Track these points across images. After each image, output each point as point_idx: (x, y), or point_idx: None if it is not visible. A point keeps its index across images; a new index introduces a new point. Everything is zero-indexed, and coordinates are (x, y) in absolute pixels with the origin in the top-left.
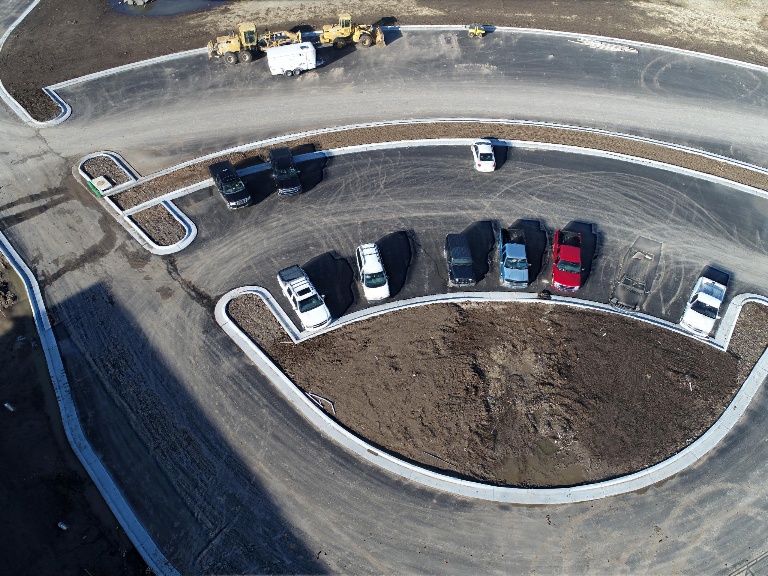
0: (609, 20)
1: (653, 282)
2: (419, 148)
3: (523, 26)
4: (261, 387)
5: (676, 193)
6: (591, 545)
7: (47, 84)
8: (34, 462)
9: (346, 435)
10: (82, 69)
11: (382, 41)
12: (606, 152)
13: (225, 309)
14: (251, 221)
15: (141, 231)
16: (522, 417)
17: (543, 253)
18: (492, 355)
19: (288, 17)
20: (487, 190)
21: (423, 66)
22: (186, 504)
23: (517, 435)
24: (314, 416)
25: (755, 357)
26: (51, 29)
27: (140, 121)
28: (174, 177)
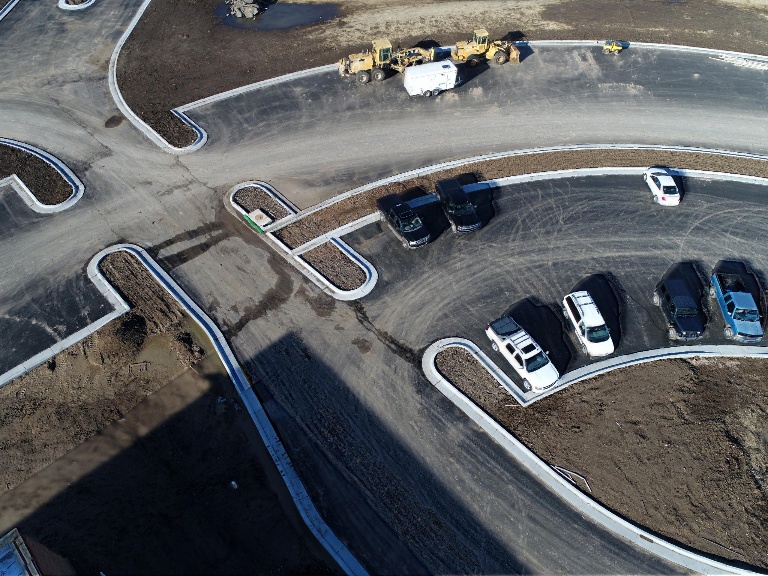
0: (748, 35)
1: None
2: (588, 178)
3: (658, 42)
4: (499, 458)
5: None
6: None
7: (175, 105)
8: (276, 551)
9: (611, 517)
10: (207, 88)
11: (517, 58)
12: None
13: (434, 365)
14: (432, 262)
15: (318, 273)
16: None
17: (759, 300)
18: (742, 420)
19: (410, 31)
20: (675, 226)
21: (565, 86)
22: None
23: None
24: (568, 494)
25: None
26: (163, 44)
27: (282, 147)
28: (335, 210)
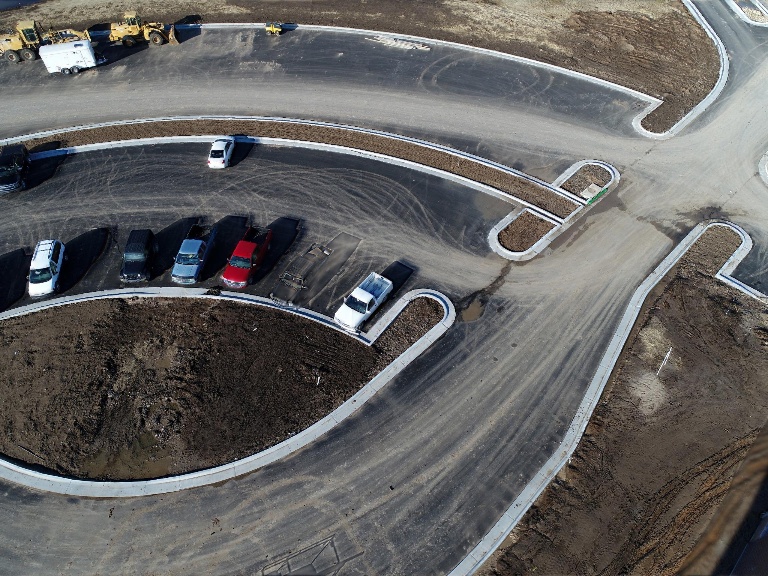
0: (412, 18)
1: (333, 277)
2: (165, 145)
3: (325, 24)
4: None
5: (401, 189)
6: (141, 537)
7: None
8: None
9: None
10: None
11: (174, 39)
12: (350, 149)
13: None
14: None
15: None
16: (135, 411)
17: None
18: (134, 350)
19: (91, 15)
20: (211, 187)
21: (207, 64)
22: None
23: (122, 429)
24: None
25: (400, 351)
26: None
27: None
28: None
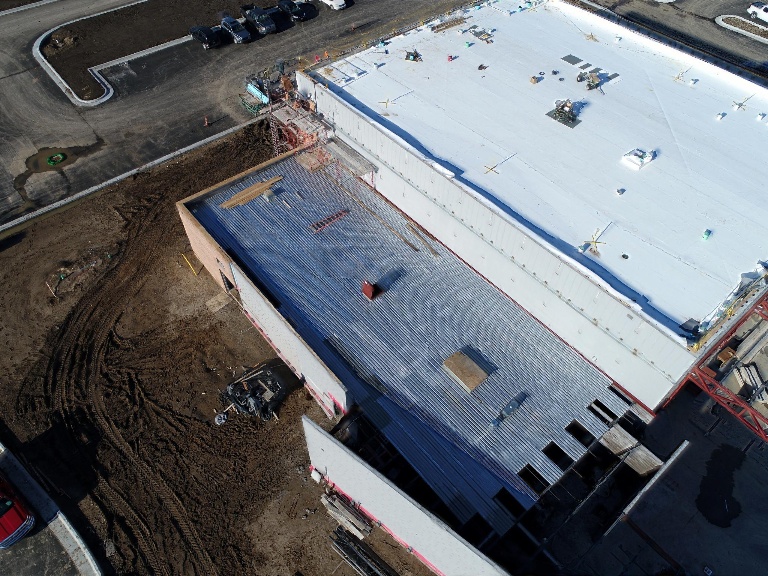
0: None
1: None
2: None
3: None
4: (767, 47)
5: None
6: None
7: None
8: None
9: None
10: None
11: None
12: None
13: None
14: None
15: None
16: None
17: None
18: None
19: None
20: None
21: None
22: (764, 76)
23: None
24: None
25: None
26: None
27: None
28: None
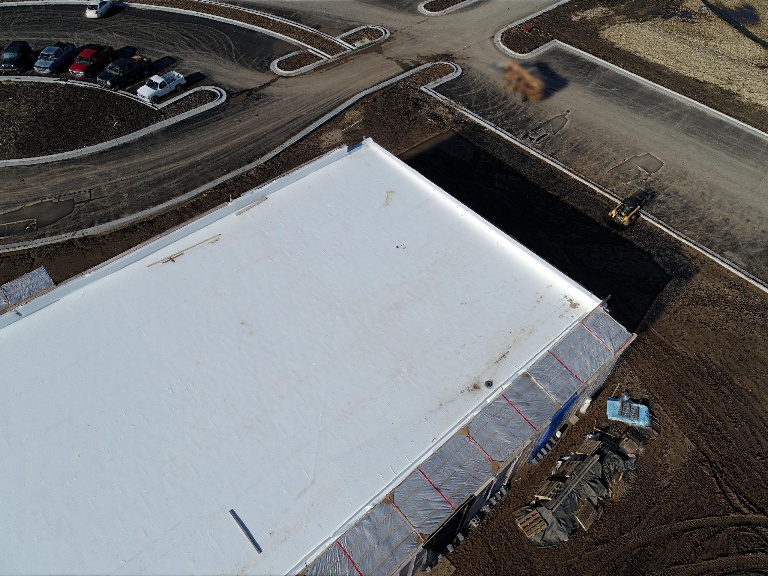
0: None
1: (149, 77)
2: (61, 5)
3: None
4: None
5: (223, 36)
6: None
7: None
8: None
9: None
10: None
11: None
12: (197, 12)
13: None
14: None
15: None
16: None
17: None
18: None
19: None
20: (85, 28)
21: None
22: None
23: None
24: None
25: None
26: None
27: None
28: None
